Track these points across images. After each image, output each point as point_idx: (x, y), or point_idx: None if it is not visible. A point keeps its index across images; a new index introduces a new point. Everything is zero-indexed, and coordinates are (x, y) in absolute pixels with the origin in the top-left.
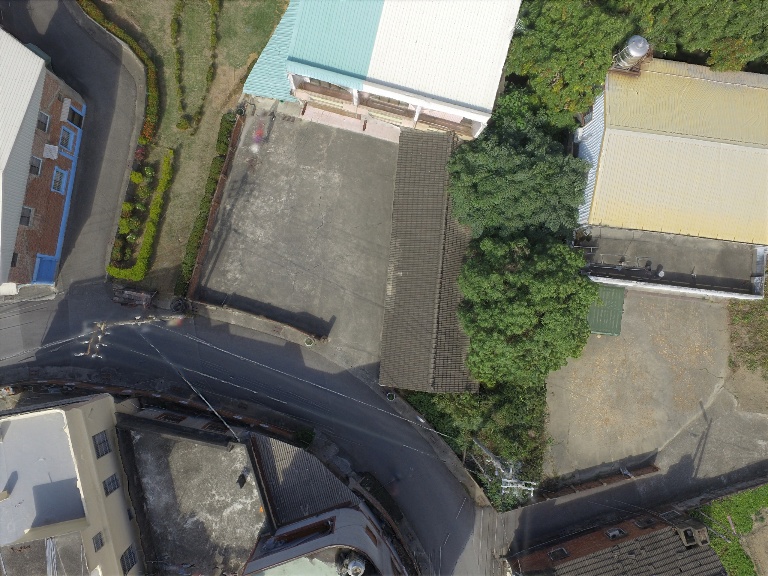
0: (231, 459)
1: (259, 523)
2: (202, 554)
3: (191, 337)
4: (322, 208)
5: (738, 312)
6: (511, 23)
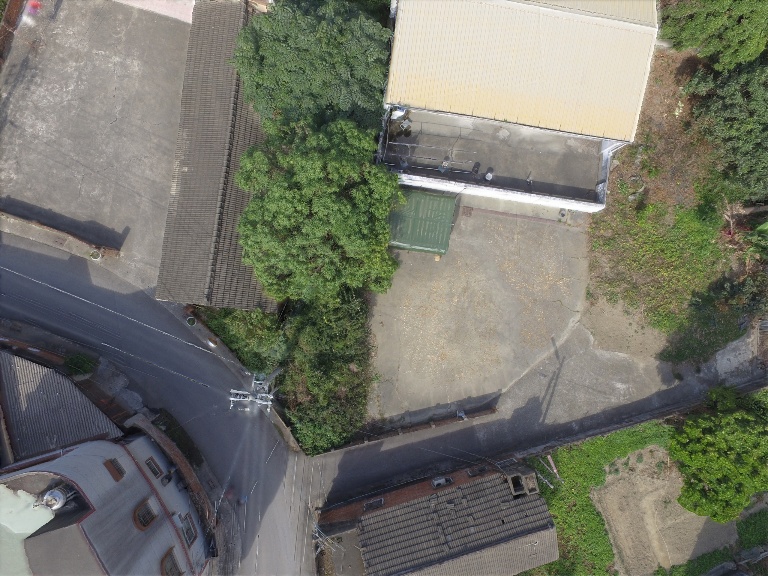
0: None
1: None
2: None
3: None
4: (117, 100)
5: (598, 238)
6: None
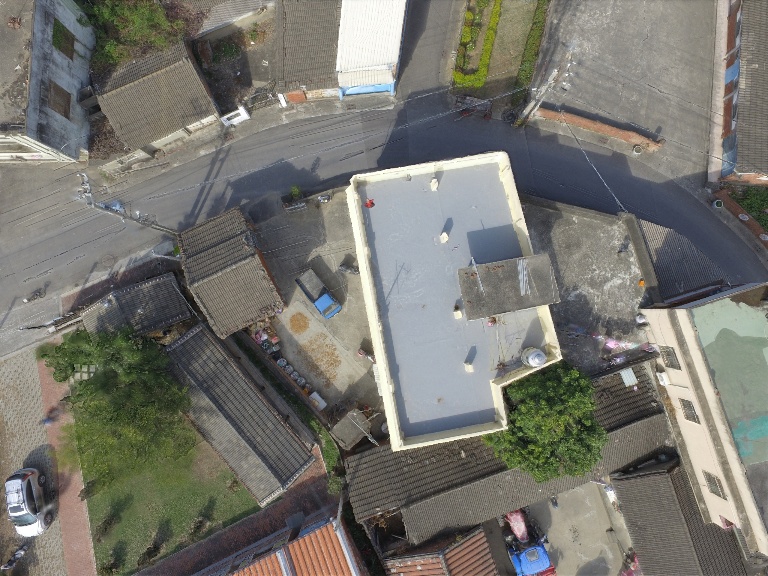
0: (609, 236)
1: (638, 297)
2: (586, 326)
3: (590, 105)
4: (647, 22)
5: None
6: None
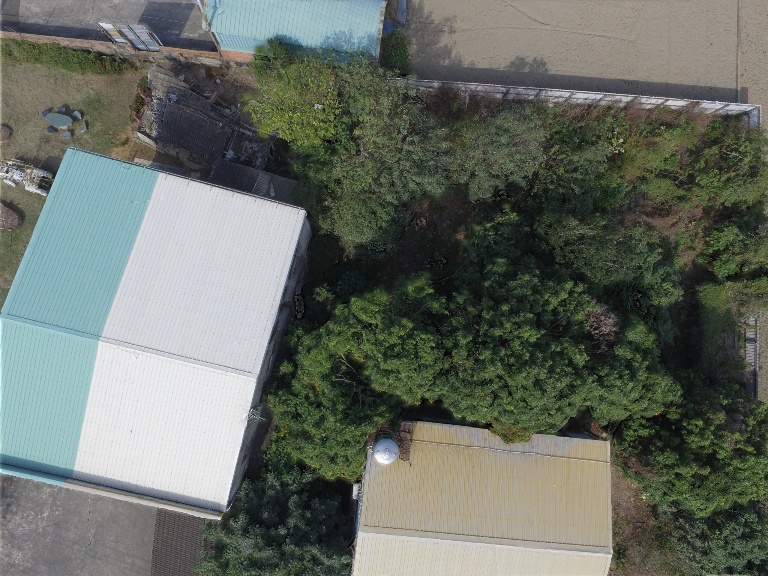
0: None
1: None
2: None
3: None
4: (91, 524)
5: None
6: (244, 410)
